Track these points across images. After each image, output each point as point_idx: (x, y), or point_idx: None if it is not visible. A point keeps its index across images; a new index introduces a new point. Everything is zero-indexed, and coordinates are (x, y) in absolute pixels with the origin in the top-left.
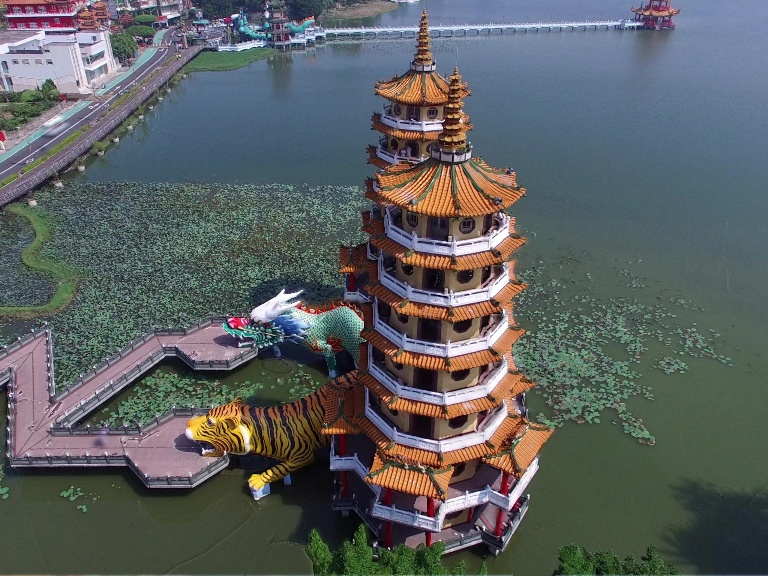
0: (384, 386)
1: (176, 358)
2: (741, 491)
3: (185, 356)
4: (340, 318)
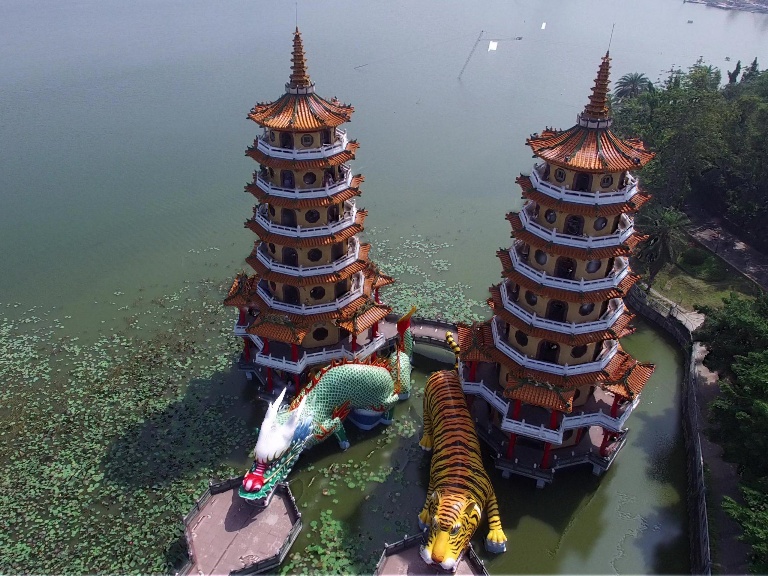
0: (594, 332)
1: None
2: None
3: (257, 565)
4: (341, 381)
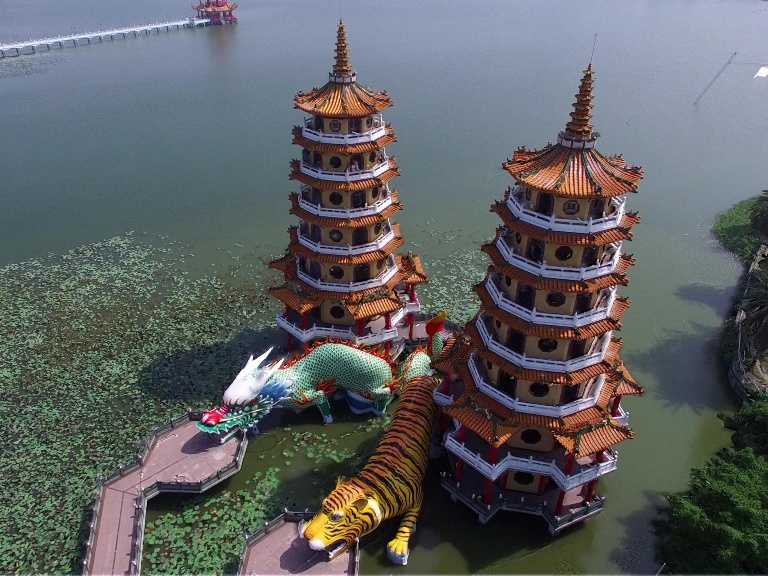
0: (548, 371)
1: (162, 495)
2: (654, 345)
3: (180, 485)
4: (329, 357)
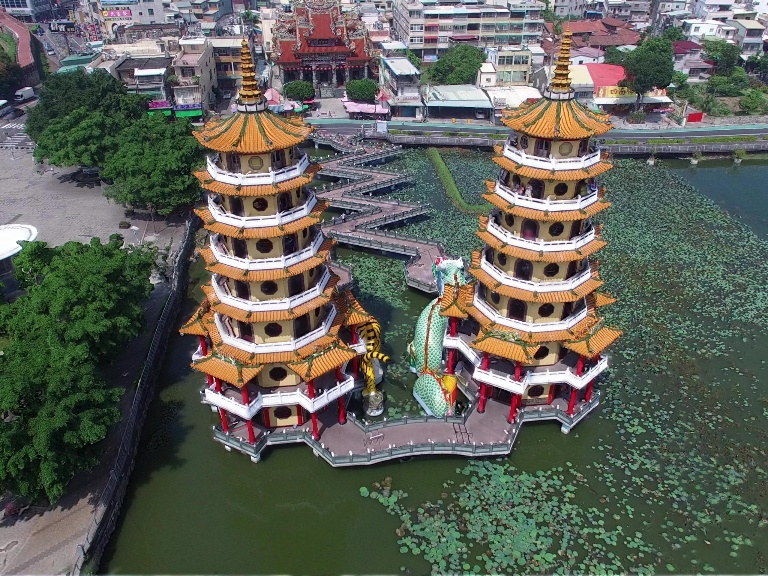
0: None
1: None
2: None
3: (411, 259)
4: None
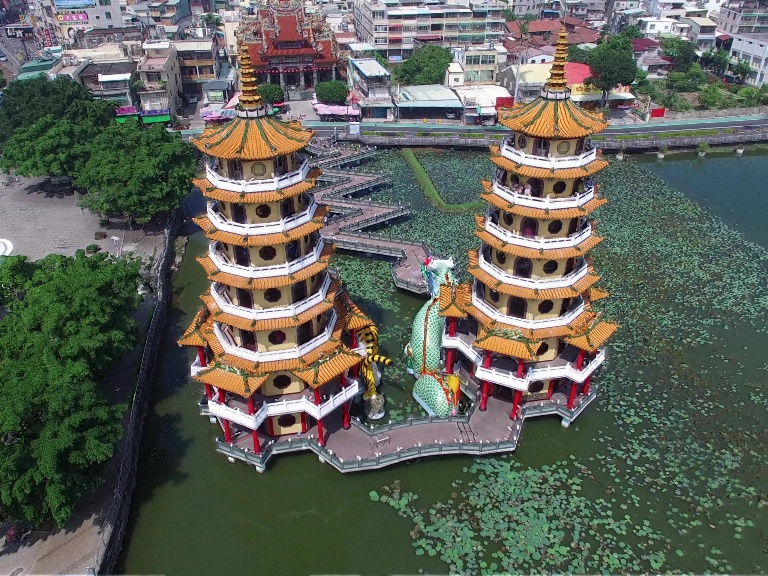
0: None
1: None
2: None
3: (398, 261)
4: None
